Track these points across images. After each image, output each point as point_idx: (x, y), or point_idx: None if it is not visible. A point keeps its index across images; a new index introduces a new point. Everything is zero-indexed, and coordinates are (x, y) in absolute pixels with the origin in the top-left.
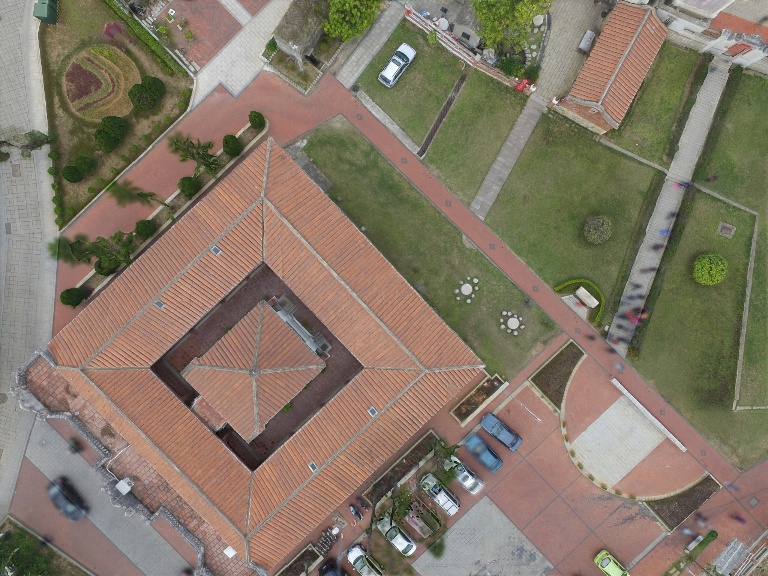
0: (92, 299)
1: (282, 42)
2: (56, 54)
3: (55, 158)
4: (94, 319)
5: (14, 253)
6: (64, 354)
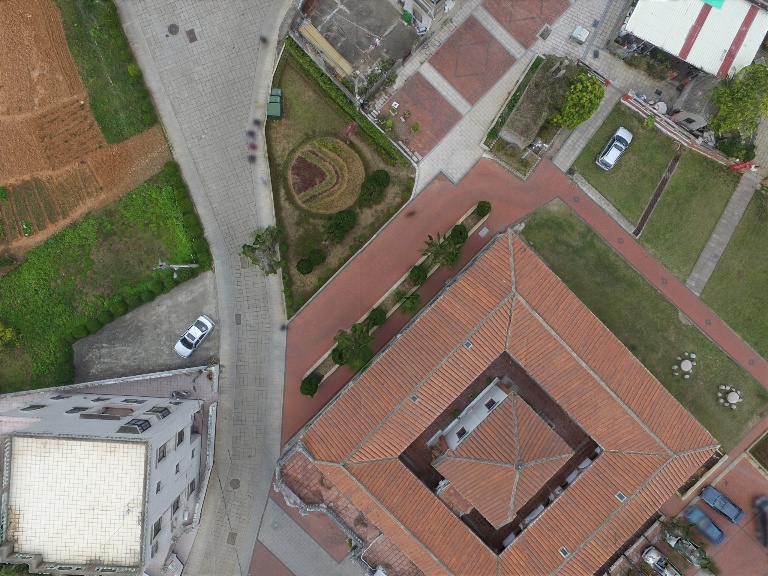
0: (321, 385)
1: (512, 134)
2: (281, 148)
3: (285, 250)
4: (347, 413)
5: (244, 343)
6: (320, 448)
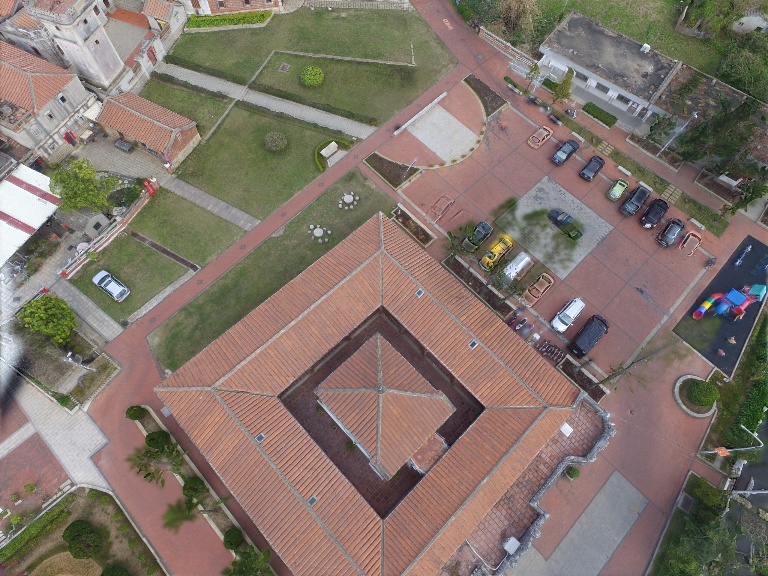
0: None
1: (62, 383)
2: None
3: None
4: None
5: None
6: None
